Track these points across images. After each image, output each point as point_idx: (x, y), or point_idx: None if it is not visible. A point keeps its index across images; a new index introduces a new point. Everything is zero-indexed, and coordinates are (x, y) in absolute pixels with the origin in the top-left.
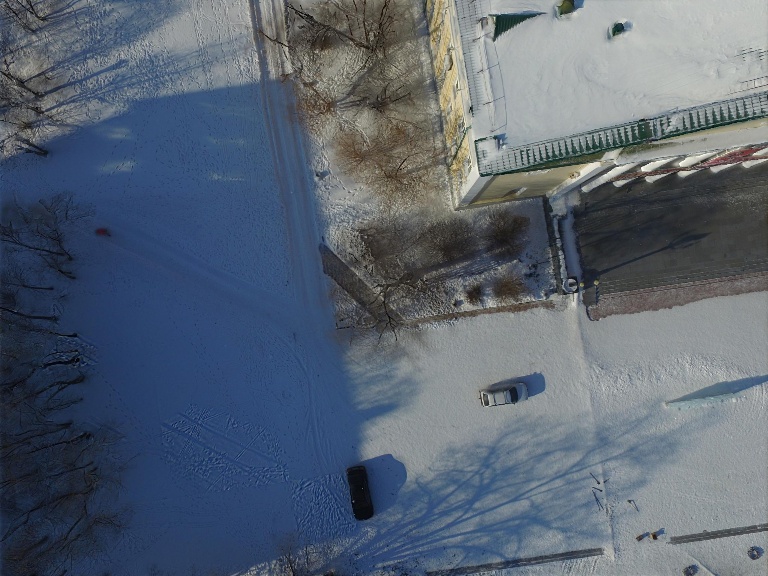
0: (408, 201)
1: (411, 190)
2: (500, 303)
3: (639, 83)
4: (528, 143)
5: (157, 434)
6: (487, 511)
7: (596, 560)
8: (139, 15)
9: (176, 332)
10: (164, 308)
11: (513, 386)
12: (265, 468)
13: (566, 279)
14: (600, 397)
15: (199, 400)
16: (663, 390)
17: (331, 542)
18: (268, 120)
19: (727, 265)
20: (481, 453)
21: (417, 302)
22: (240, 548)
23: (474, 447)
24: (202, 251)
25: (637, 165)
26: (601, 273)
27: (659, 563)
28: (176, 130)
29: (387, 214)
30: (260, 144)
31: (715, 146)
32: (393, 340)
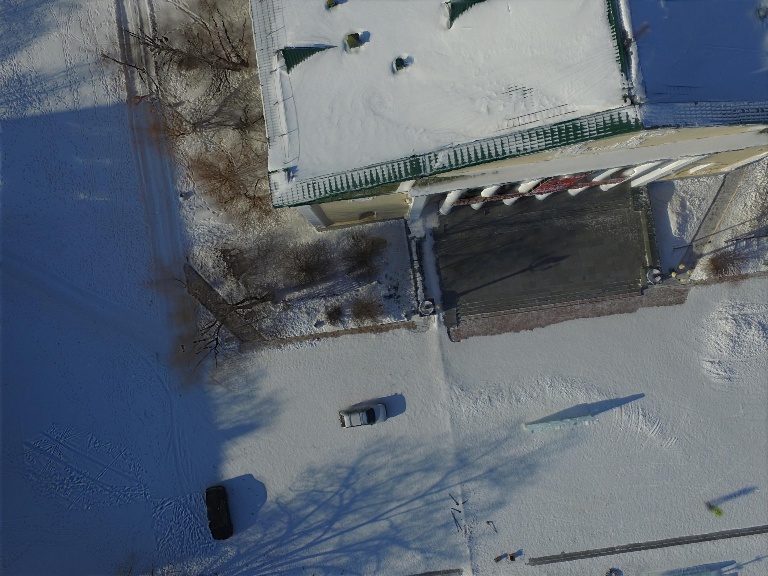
0: (272, 222)
1: (275, 211)
2: (361, 324)
3: (420, 118)
4: (315, 176)
5: (19, 453)
6: (346, 531)
7: None
8: (8, 35)
9: (39, 351)
10: (28, 327)
11: (371, 407)
12: (126, 487)
13: (422, 301)
14: (460, 418)
15: (61, 419)
16: (523, 412)
17: (191, 561)
18: (134, 140)
19: (586, 287)
20: (341, 473)
21: (279, 323)
22: (100, 567)
23: (334, 467)
24: (67, 270)
25: (473, 191)
26: (460, 295)
27: None
28: (43, 150)
29: (251, 235)
30: (126, 164)
31: (506, 179)
32: (255, 360)
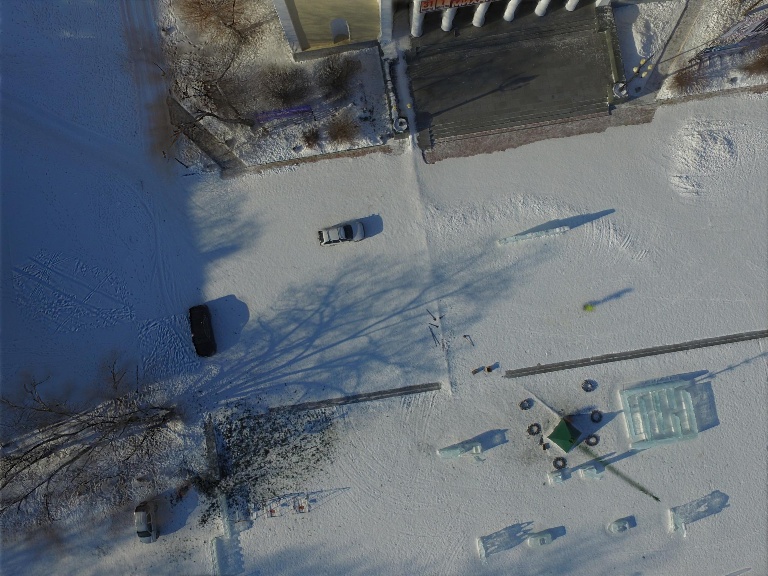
0: (251, 54)
1: (254, 44)
2: (338, 148)
3: None
4: None
5: (8, 278)
6: (327, 348)
7: (434, 395)
8: None
9: (28, 181)
10: (17, 159)
11: (348, 224)
12: (112, 310)
13: (396, 118)
14: (436, 237)
15: (49, 245)
16: (497, 229)
17: (176, 380)
18: None
19: (555, 106)
20: (321, 292)
21: (259, 148)
22: (88, 387)
23: (314, 287)
24: (54, 105)
25: None
26: (433, 116)
27: (496, 397)
28: None
29: (231, 67)
30: (110, 3)
31: None
32: (237, 186)
